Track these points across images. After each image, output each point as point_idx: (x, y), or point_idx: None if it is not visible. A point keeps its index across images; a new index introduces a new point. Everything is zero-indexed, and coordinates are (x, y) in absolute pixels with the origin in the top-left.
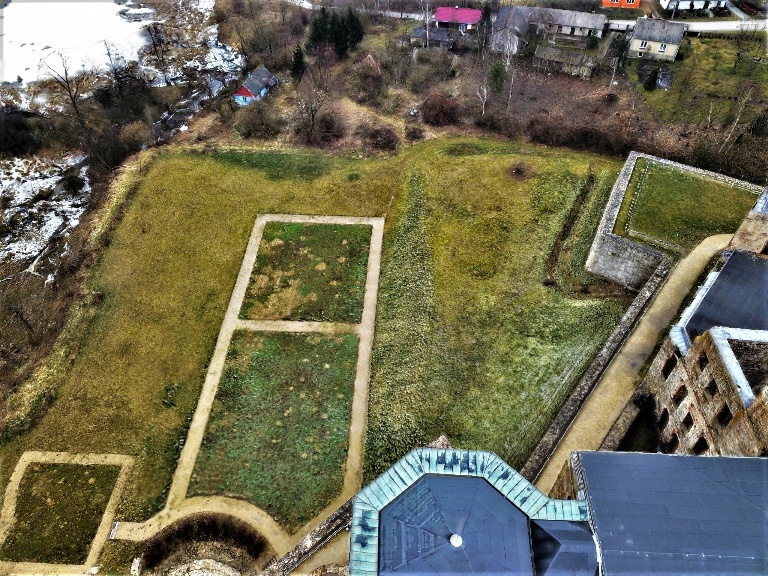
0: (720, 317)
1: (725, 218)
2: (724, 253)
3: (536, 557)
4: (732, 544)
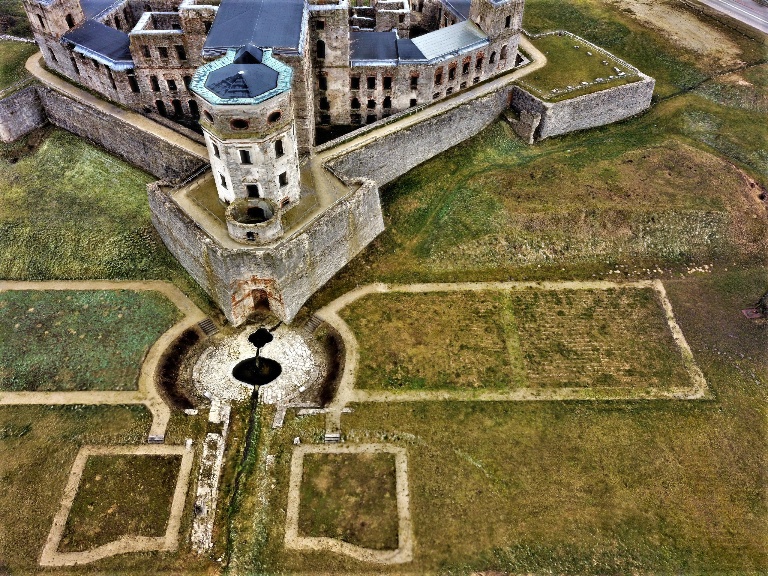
0: (113, 49)
1: (11, 58)
2: (61, 41)
3: (250, 62)
4: (252, 22)
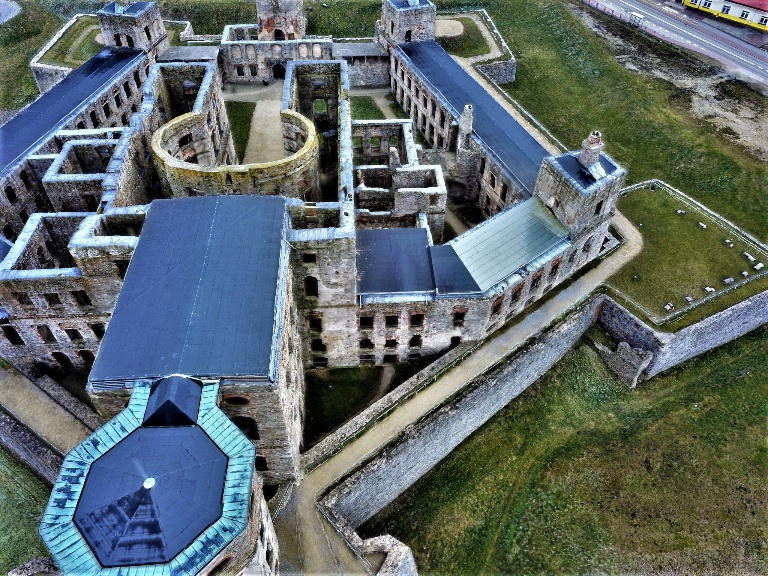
0: None
1: None
2: None
3: (175, 424)
4: (187, 296)
